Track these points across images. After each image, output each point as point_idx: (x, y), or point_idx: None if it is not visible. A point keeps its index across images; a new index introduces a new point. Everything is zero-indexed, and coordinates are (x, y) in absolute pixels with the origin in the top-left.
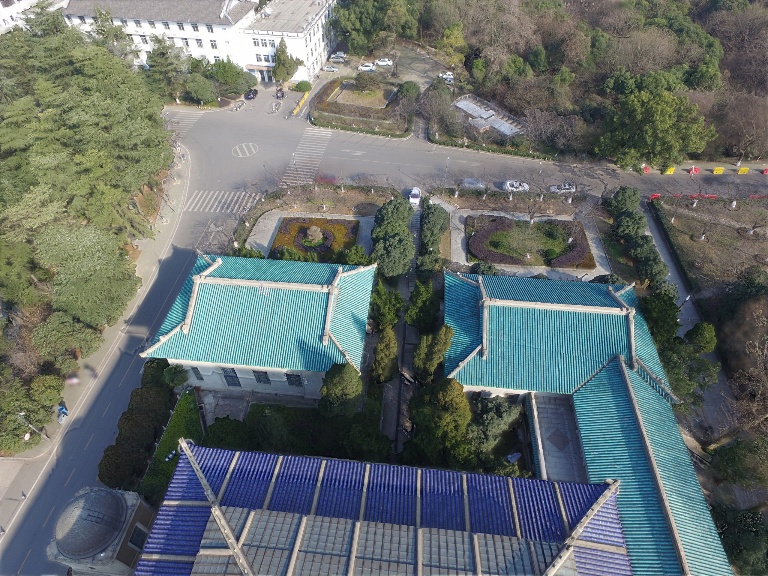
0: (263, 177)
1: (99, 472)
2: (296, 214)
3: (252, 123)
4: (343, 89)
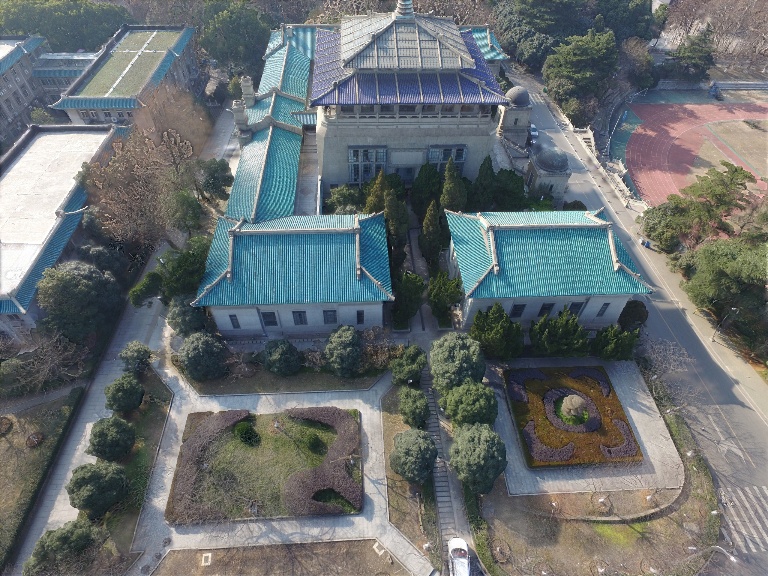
0: None
1: None
2: (637, 483)
3: None
4: None
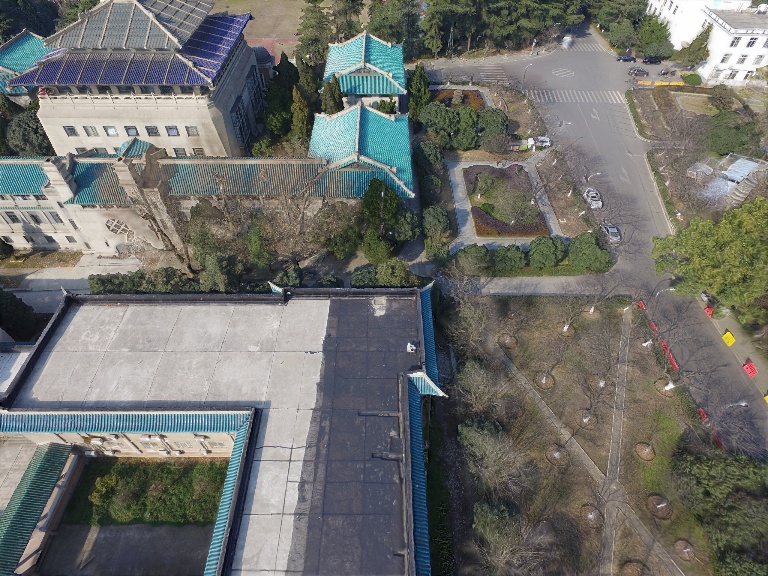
0: (530, 83)
1: None
2: (489, 97)
3: (605, 69)
4: (709, 98)
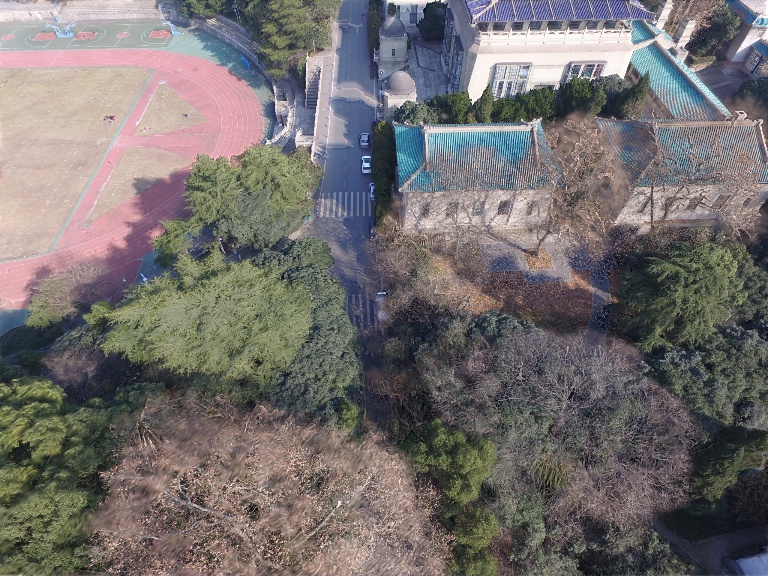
0: None
1: (370, 45)
2: None
3: None
4: None
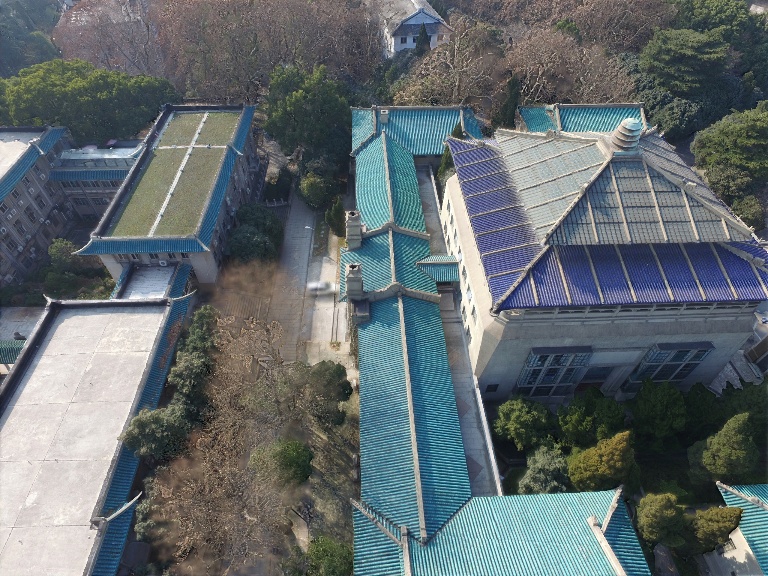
0: None
1: None
2: None
3: None
4: None
